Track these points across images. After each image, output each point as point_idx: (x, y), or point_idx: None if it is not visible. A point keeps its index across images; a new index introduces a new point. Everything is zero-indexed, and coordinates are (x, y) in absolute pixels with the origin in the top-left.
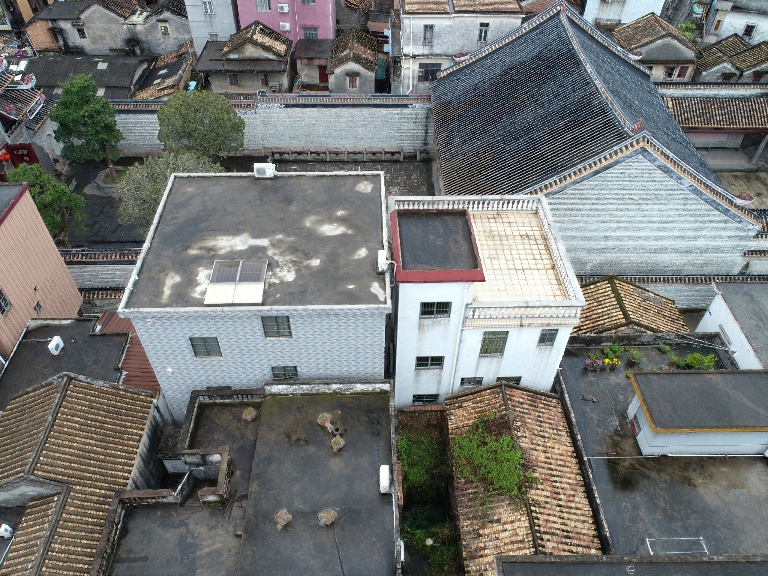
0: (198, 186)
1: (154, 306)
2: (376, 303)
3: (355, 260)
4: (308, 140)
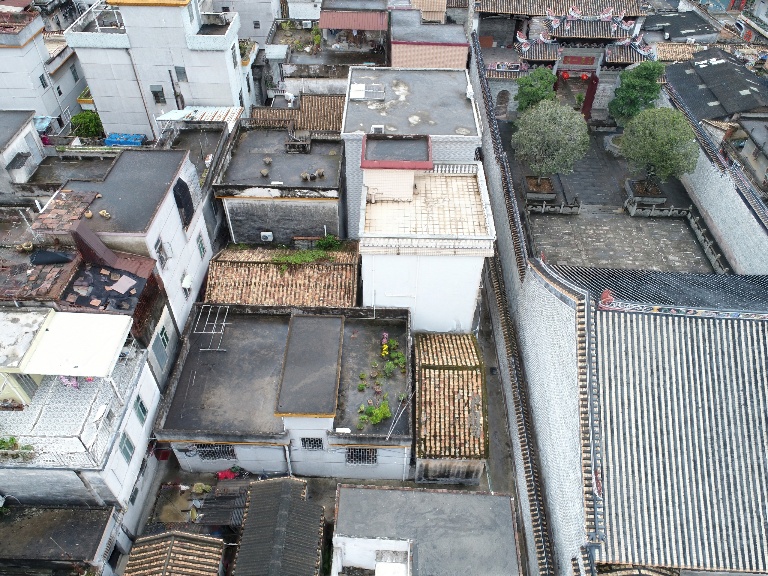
0: (456, 78)
1: (354, 75)
2: (347, 131)
3: (385, 126)
4: (728, 233)
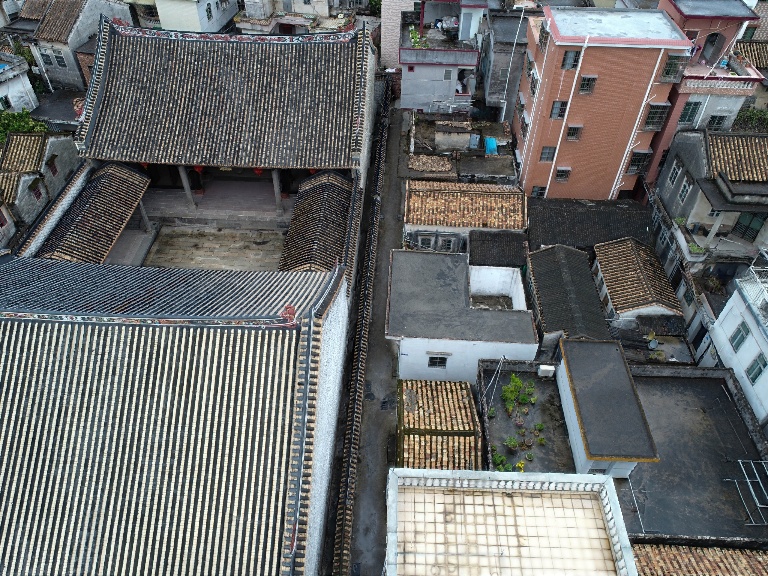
0: None
1: None
2: None
3: None
4: None
